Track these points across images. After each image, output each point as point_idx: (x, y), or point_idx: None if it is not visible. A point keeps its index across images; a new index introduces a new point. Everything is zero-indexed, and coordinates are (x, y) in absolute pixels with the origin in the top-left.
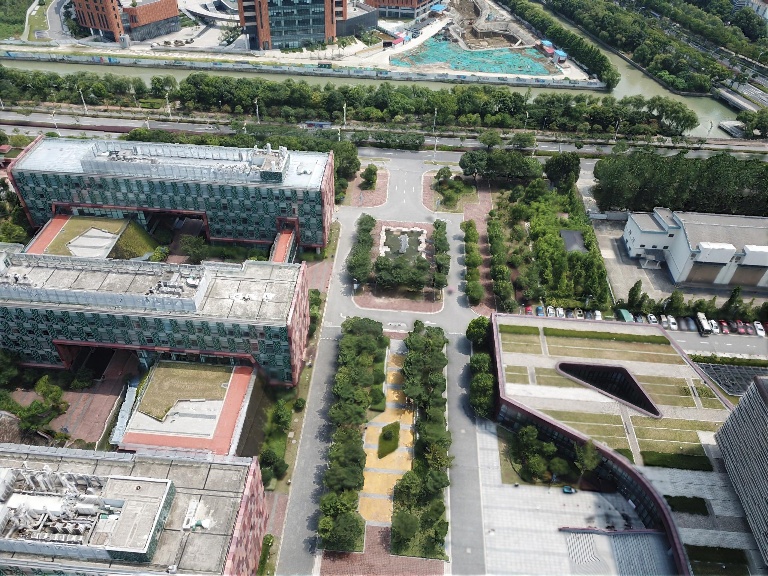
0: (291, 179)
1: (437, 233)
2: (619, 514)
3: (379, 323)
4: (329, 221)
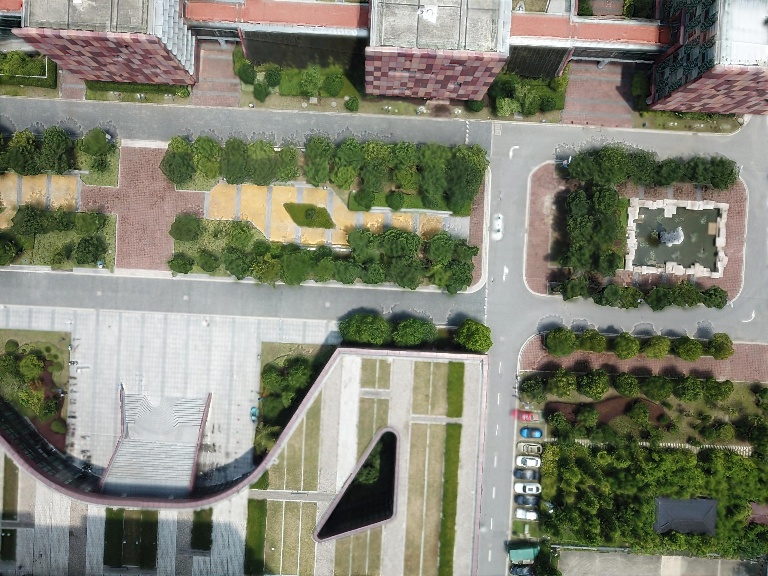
0: (750, 7)
1: (687, 290)
2: (230, 461)
3: (470, 195)
4: (708, 106)
